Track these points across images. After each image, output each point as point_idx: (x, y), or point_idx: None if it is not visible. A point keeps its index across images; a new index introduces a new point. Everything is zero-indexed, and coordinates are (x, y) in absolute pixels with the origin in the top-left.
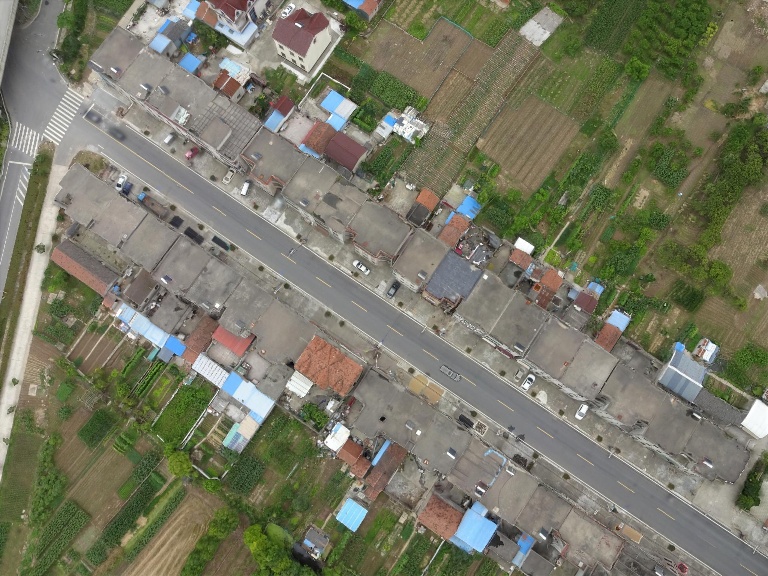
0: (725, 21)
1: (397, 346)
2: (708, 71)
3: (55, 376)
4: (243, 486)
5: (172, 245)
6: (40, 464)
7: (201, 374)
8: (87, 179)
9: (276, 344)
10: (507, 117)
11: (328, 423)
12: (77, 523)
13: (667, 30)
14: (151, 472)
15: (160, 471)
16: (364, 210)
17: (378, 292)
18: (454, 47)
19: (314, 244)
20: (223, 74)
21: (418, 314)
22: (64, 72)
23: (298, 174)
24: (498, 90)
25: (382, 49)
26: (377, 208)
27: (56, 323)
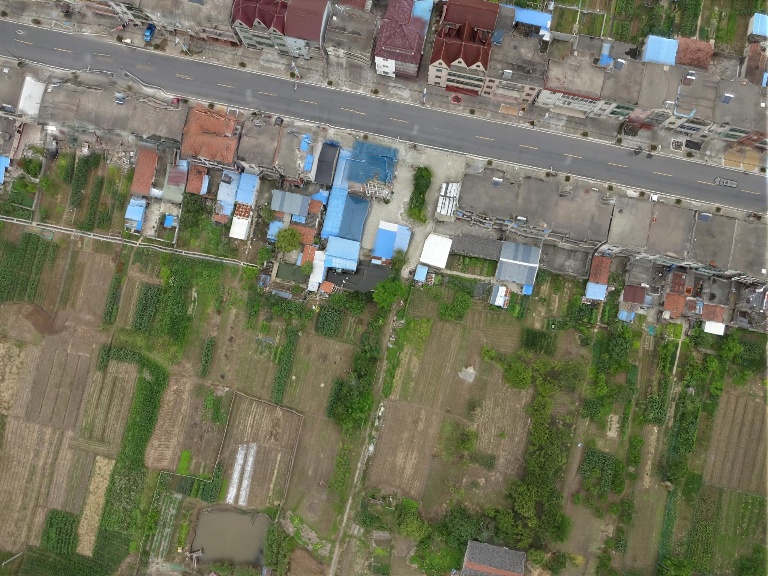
0: None
1: None
2: None
3: None
4: None
5: None
6: None
7: None
8: None
9: None
10: None
11: None
12: None
13: None
14: None
15: None
16: None
17: None
18: None
19: None
20: None
21: None
22: None
23: None
24: None
25: None
26: None
27: None
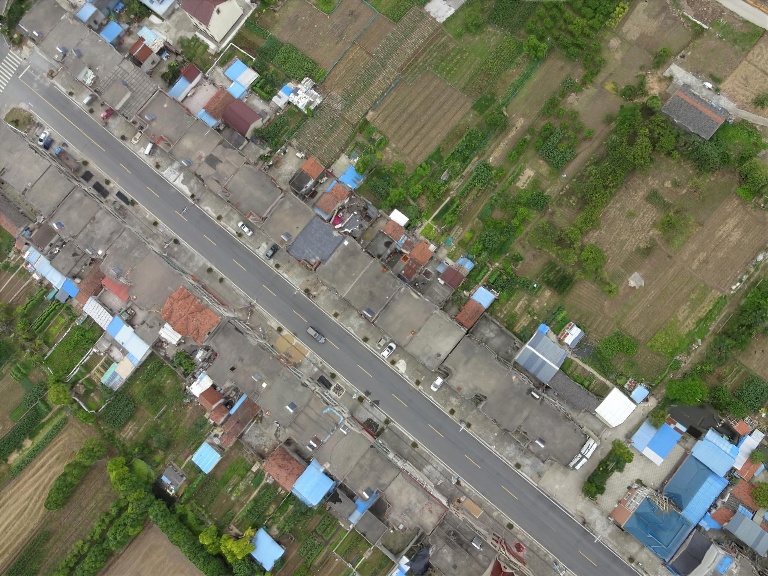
0: (639, 1)
1: (269, 305)
2: (613, 52)
3: None
4: (115, 421)
5: (68, 195)
6: None
7: (91, 316)
8: (4, 131)
9: (147, 291)
10: (401, 91)
11: (196, 371)
12: None
13: (574, 9)
14: (38, 400)
15: (47, 400)
16: (241, 172)
17: (259, 253)
18: (359, 22)
19: (206, 204)
20: (138, 41)
21: (293, 276)
22: (8, 36)
23: (185, 135)
24: (393, 64)
25: (290, 22)
26: (253, 171)
27: None
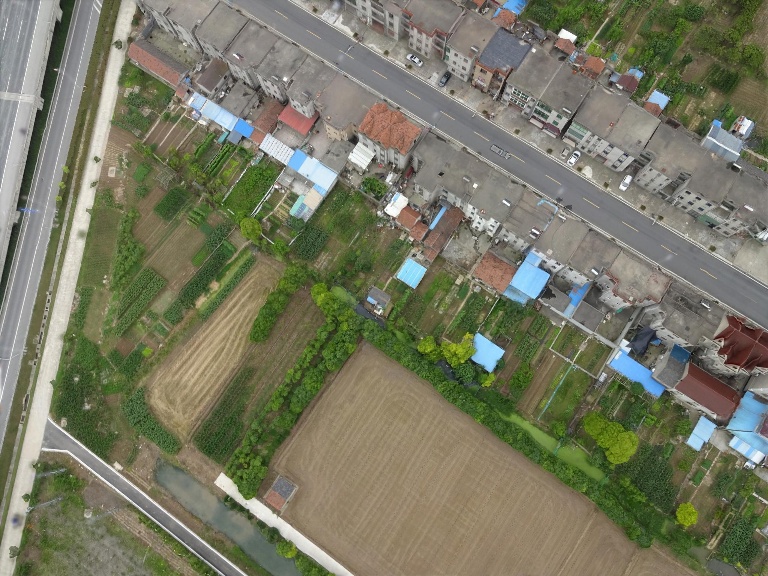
0: None
1: (450, 129)
2: None
3: (132, 160)
4: (309, 252)
5: (242, 28)
6: (120, 234)
7: (268, 154)
8: None
9: (340, 112)
10: None
11: (387, 194)
12: (155, 286)
13: None
14: (223, 240)
15: (231, 241)
16: None
17: (431, 82)
18: None
19: (370, 42)
20: None
21: (469, 101)
22: None
23: None
24: None
25: None
26: None
27: (132, 114)
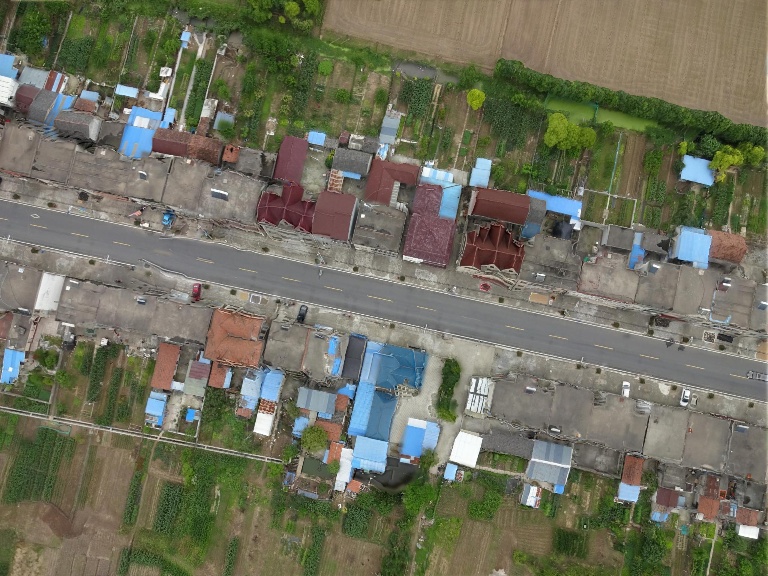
0: None
1: None
2: None
3: None
4: None
5: None
6: None
7: None
8: None
9: None
10: None
11: None
12: None
13: None
14: None
15: None
16: None
17: None
18: None
19: None
20: None
21: None
22: None
23: None
24: None
25: None
26: None
27: None
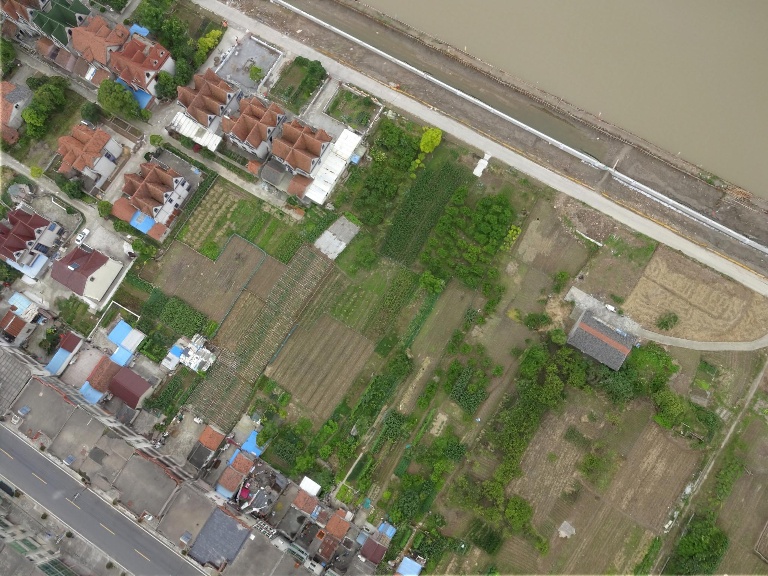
0: (531, 220)
1: None
2: (512, 277)
3: None
4: None
5: None
6: None
7: None
8: None
9: None
10: (299, 339)
11: None
12: None
13: (467, 235)
14: None
15: None
16: (130, 465)
17: (162, 538)
18: (247, 265)
19: None
20: (8, 313)
21: None
22: None
23: (66, 428)
24: (287, 313)
25: (174, 271)
26: (143, 462)
27: None
